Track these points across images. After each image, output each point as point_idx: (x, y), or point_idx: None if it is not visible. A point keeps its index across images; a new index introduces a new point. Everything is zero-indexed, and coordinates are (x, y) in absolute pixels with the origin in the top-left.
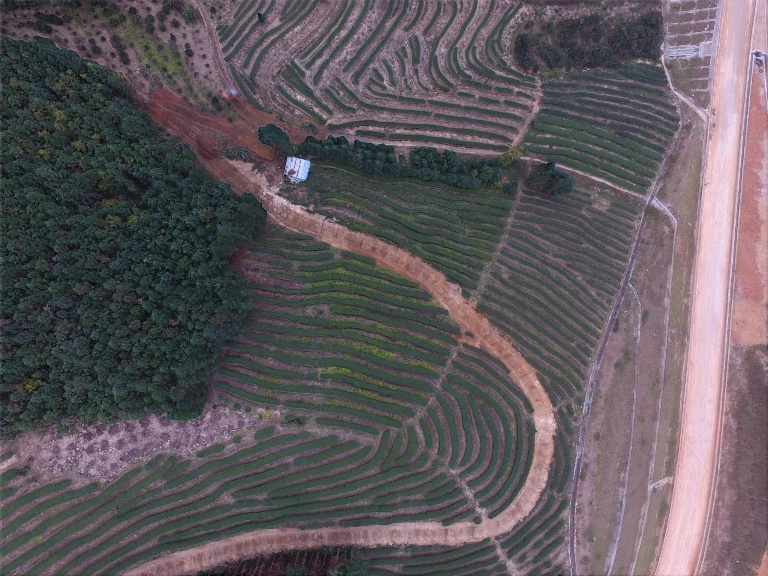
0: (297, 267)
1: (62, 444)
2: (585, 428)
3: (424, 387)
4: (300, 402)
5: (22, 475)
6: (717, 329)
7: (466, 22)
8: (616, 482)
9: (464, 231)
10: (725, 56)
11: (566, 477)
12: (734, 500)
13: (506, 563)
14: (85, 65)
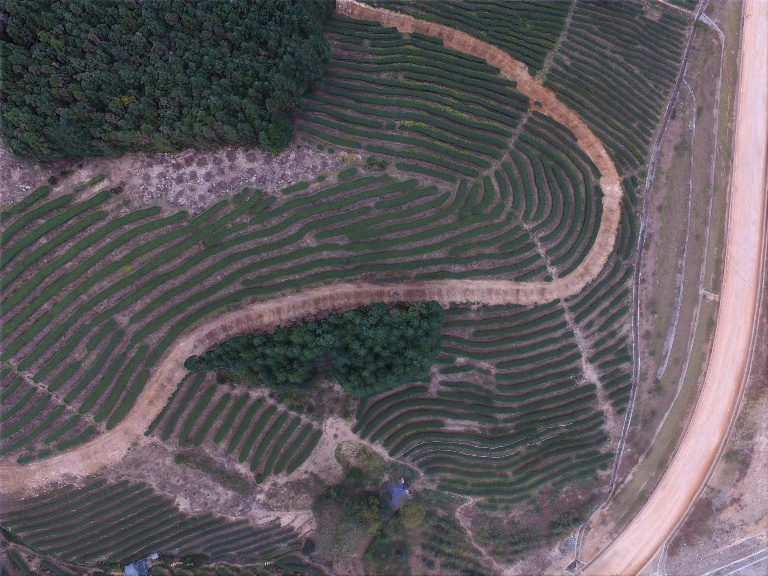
0: (368, 44)
1: (152, 172)
2: (648, 201)
3: (498, 142)
4: (381, 147)
5: (115, 193)
6: (759, 154)
7: None
8: (674, 267)
9: (526, 25)
10: None
11: (632, 244)
12: None
13: (573, 331)
14: None
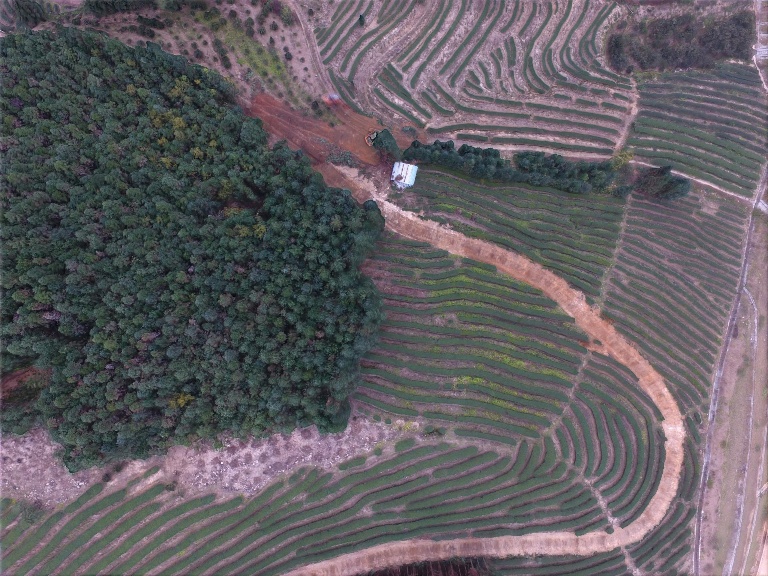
0: (419, 275)
1: (206, 458)
2: (711, 436)
3: (559, 396)
4: (439, 413)
5: (171, 490)
6: None
7: (561, 23)
8: (735, 489)
9: (580, 237)
10: None
11: (695, 485)
12: None
13: (632, 572)
14: (199, 71)
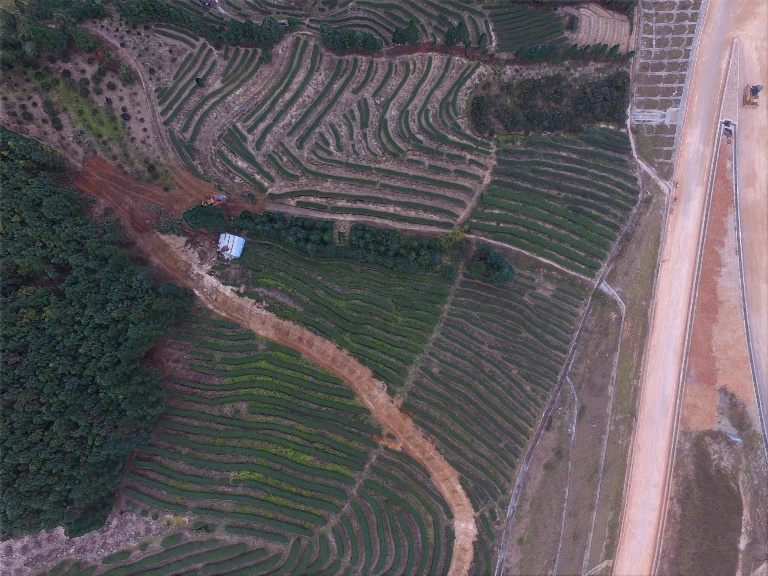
0: (219, 359)
1: None
2: (508, 532)
3: (338, 494)
4: (209, 509)
5: None
6: (667, 412)
7: (419, 83)
8: None
9: (397, 320)
10: (692, 125)
11: None
12: None
13: None
14: (7, 142)
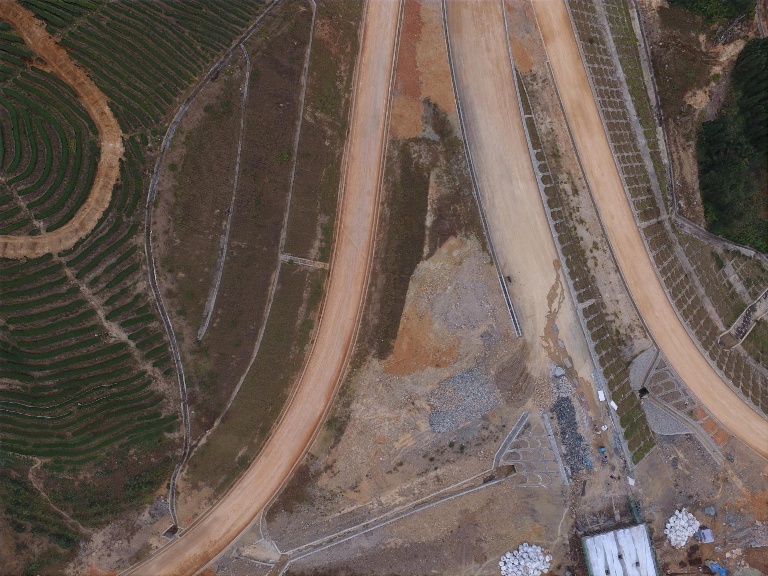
0: None
1: None
2: (162, 159)
3: None
4: None
5: None
6: (378, 124)
7: None
8: (216, 228)
9: None
10: None
11: (134, 200)
12: (383, 283)
13: (80, 287)
14: None
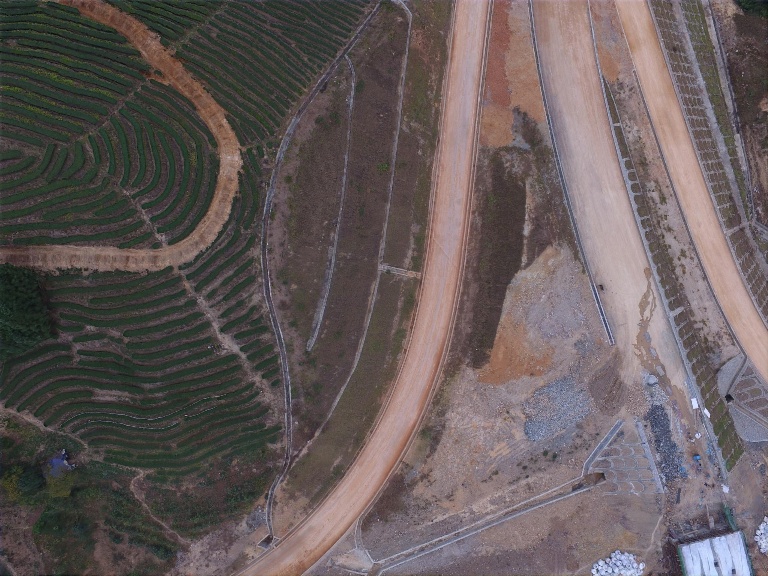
0: None
1: None
2: (277, 172)
3: (97, 108)
4: None
5: None
6: (467, 133)
7: None
8: (324, 239)
9: None
10: None
11: (252, 213)
12: (476, 292)
13: (197, 300)
14: None
